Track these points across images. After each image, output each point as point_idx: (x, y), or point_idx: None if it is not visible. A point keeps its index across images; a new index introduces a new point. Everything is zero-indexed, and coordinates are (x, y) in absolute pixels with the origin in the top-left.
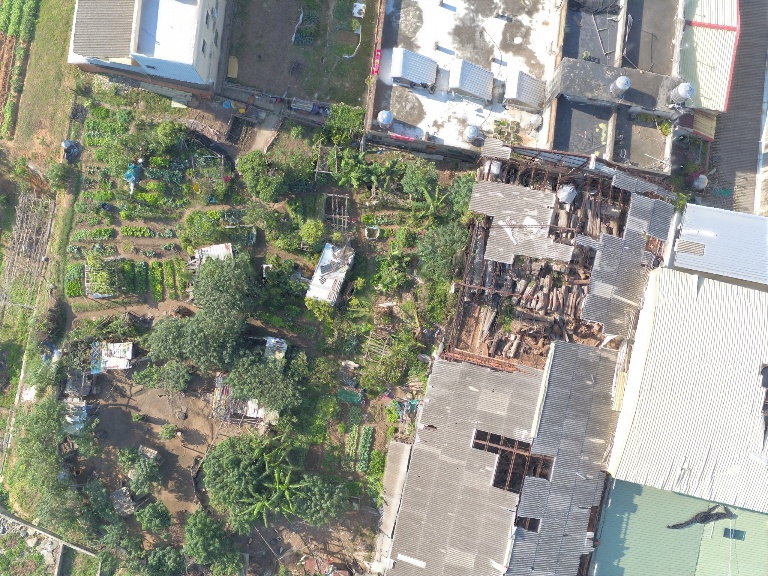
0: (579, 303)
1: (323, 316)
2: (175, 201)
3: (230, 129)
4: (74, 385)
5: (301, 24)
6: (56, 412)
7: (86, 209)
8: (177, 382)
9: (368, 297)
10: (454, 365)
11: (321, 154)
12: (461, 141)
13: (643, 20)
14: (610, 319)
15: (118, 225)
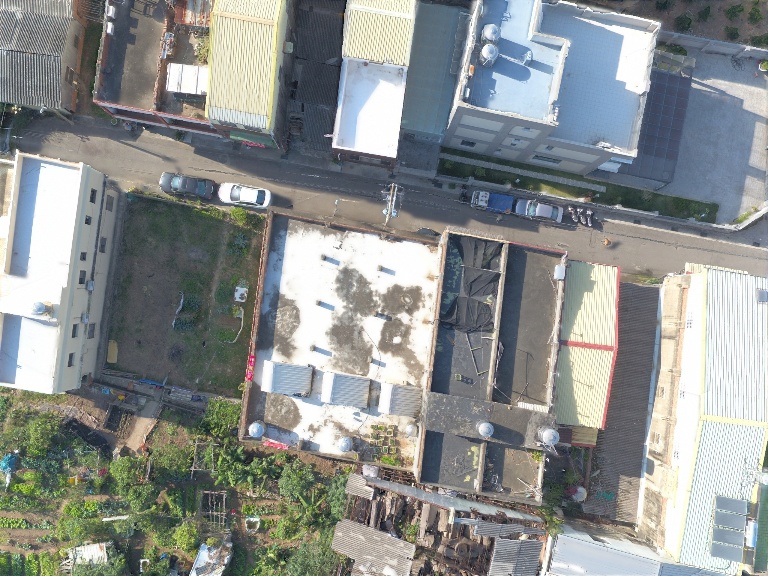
0: None
1: None
2: (52, 491)
3: (109, 417)
4: None
5: (181, 310)
6: None
7: None
8: None
9: None
10: None
11: (198, 451)
12: (337, 446)
13: (518, 338)
14: None
15: None
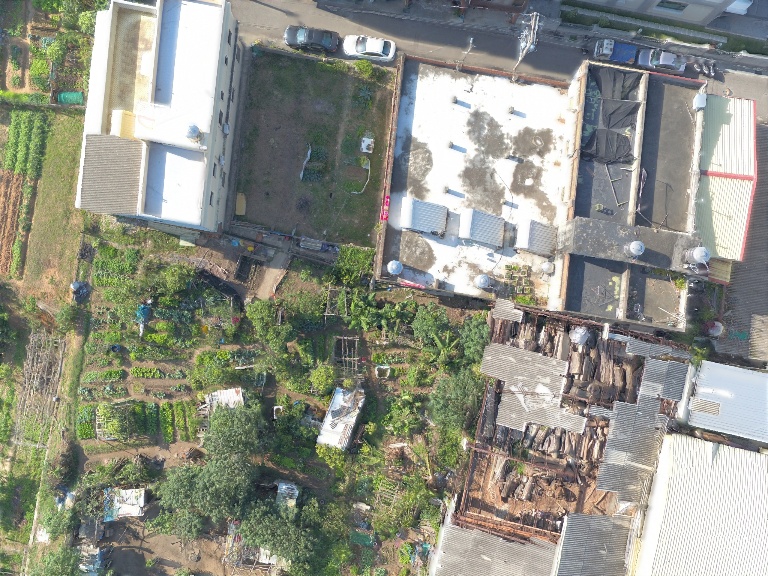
0: (591, 446)
1: (334, 464)
2: (185, 341)
3: (239, 268)
4: (87, 529)
5: (309, 161)
6: (70, 566)
7: (96, 351)
8: (189, 531)
9: (379, 437)
10: (466, 532)
11: (330, 297)
12: (472, 286)
13: (657, 169)
14: (623, 485)
15: (128, 366)
